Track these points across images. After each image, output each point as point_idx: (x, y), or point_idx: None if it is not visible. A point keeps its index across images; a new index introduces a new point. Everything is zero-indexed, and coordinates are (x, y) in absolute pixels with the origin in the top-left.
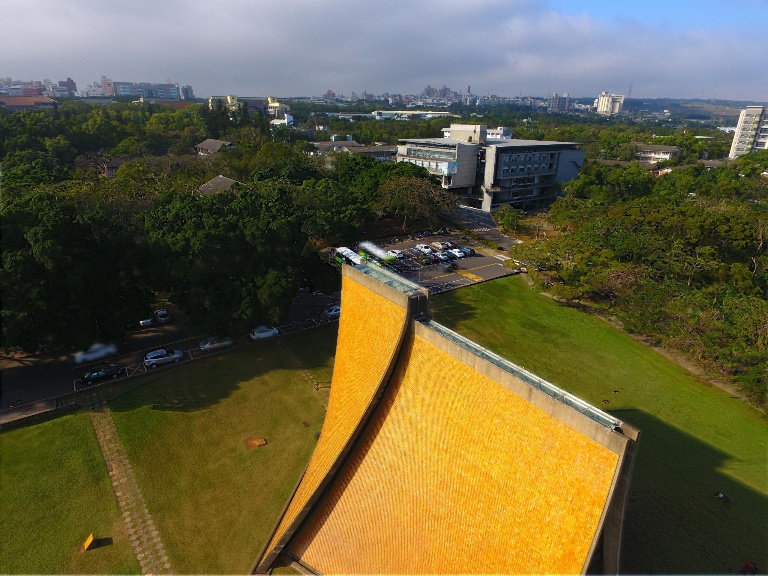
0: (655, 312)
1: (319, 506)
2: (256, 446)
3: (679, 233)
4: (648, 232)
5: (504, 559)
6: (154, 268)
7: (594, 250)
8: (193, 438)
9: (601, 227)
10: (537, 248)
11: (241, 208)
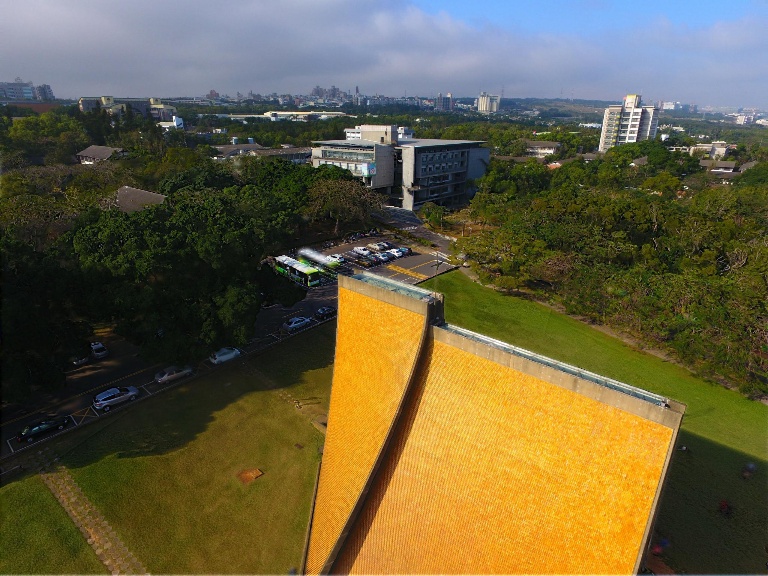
0: (593, 293)
1: (352, 529)
2: (252, 478)
3: (596, 221)
4: (571, 222)
5: (562, 544)
6: (93, 297)
7: (528, 241)
8: (178, 482)
9: (530, 219)
10: (475, 243)
11: (184, 222)
